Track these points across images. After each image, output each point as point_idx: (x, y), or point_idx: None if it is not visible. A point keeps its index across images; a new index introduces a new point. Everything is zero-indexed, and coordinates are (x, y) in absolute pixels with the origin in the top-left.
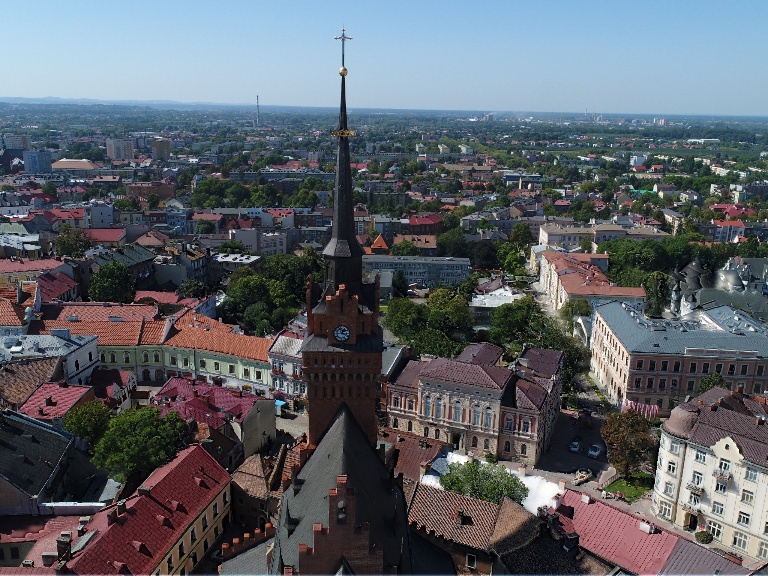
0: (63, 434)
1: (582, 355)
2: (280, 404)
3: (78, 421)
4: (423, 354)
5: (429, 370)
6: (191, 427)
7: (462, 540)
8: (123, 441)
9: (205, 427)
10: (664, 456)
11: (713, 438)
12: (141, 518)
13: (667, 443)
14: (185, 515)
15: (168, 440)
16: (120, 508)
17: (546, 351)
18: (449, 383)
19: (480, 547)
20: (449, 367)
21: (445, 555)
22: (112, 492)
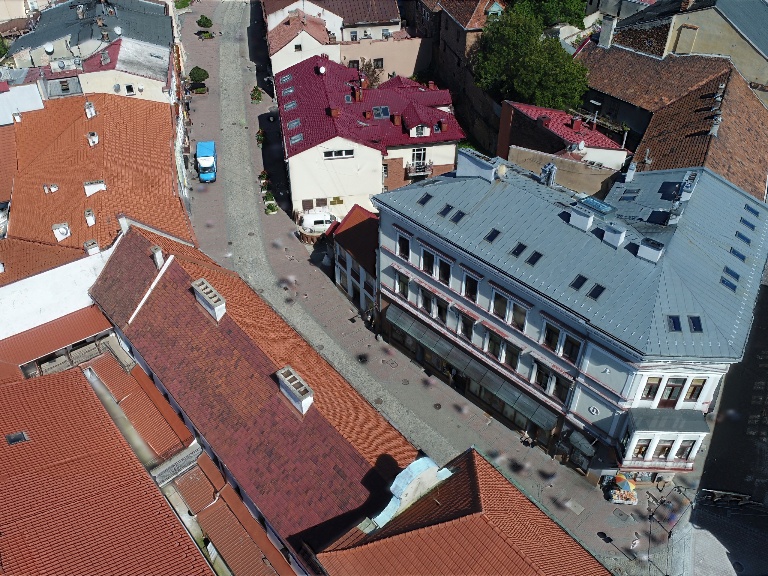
0: None
1: None
2: (210, 143)
3: None
4: None
5: None
6: None
7: None
8: None
9: None
10: None
11: None
12: None
13: None
14: None
15: None
16: None
17: None
18: None
19: None
20: None
21: None
22: (568, 50)
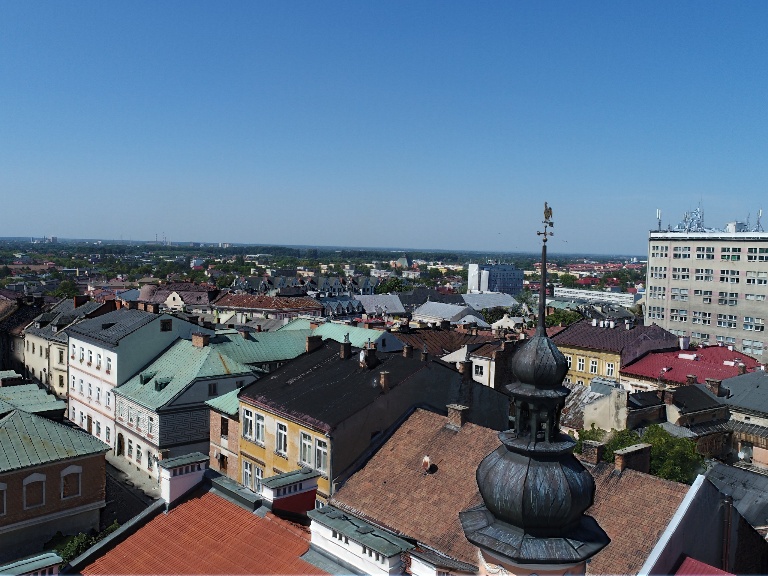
0: None
1: None
2: None
3: None
4: None
5: None
6: None
7: None
8: None
9: None
10: None
11: (166, 297)
12: None
13: None
14: None
15: None
16: None
17: None
18: None
19: None
20: None
21: None
22: None
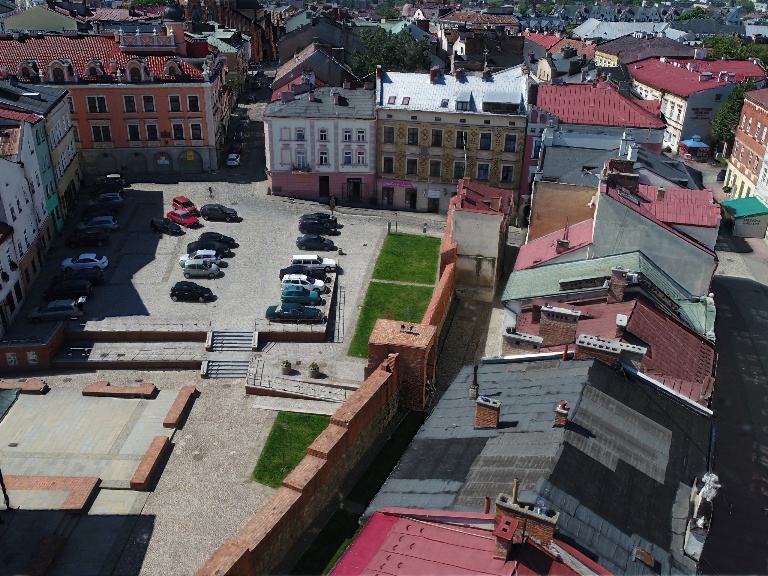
0: None
1: None
2: None
3: None
4: None
5: None
6: None
7: (280, 25)
8: (140, 0)
9: None
10: None
11: None
12: (149, 11)
13: None
14: None
15: (160, 2)
16: (140, 6)
17: None
18: None
19: None
20: None
21: (268, 19)
22: None
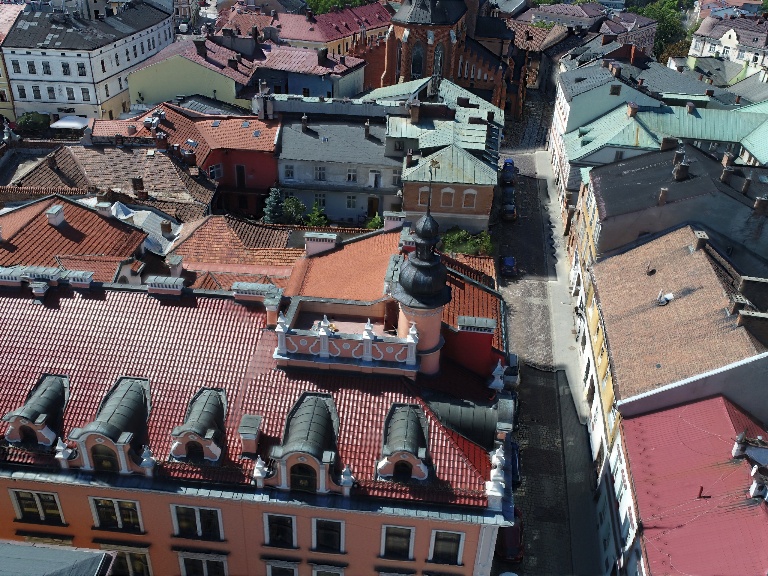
0: (300, 0)
1: (677, 32)
2: None
3: (307, 2)
4: (542, 4)
5: (541, 7)
6: (375, 0)
7: (525, 47)
8: None
9: (384, 0)
10: (690, 53)
11: (723, 33)
12: (346, 16)
13: (693, 43)
14: (369, 25)
15: None
16: (336, 8)
17: (642, 17)
18: (554, 15)
19: (534, 50)
20: (557, 6)
21: None
22: None
